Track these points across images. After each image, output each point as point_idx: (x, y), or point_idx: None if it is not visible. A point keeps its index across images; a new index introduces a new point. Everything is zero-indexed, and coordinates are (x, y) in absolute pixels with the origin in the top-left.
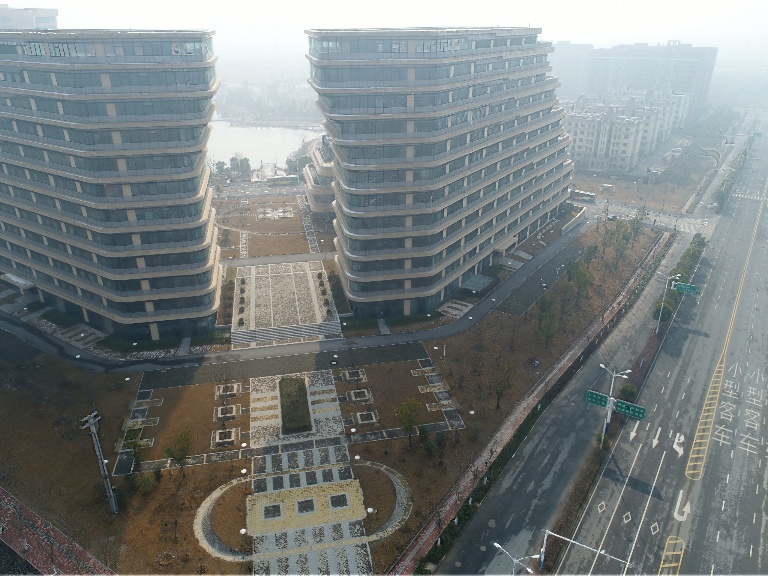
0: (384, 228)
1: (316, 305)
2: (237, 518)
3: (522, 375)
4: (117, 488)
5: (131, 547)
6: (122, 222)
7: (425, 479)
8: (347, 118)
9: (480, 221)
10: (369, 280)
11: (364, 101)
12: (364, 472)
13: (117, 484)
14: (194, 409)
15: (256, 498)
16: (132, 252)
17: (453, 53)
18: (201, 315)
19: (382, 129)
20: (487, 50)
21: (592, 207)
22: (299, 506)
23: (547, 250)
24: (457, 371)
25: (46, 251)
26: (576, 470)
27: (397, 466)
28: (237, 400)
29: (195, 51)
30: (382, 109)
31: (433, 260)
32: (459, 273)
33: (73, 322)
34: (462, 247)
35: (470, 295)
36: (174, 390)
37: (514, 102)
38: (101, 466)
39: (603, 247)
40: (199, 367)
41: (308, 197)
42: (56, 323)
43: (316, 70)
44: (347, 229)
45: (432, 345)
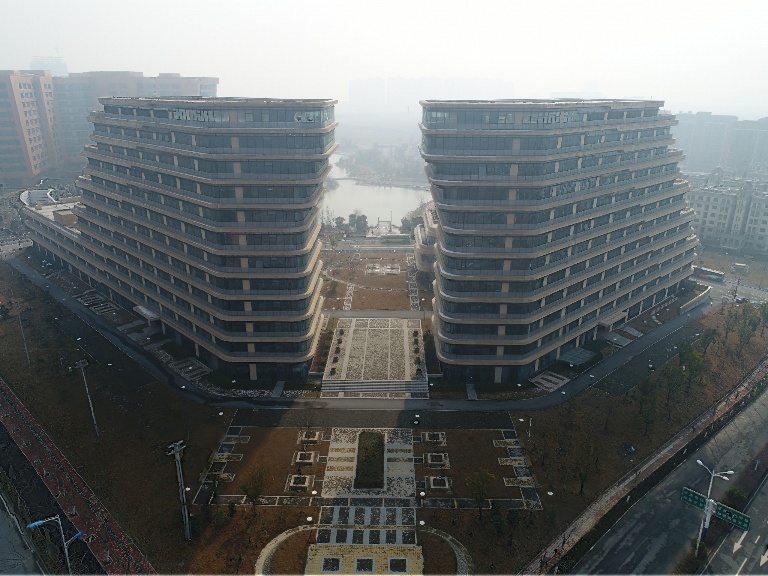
0: (479, 292)
1: (407, 362)
2: (297, 565)
3: (614, 461)
4: (194, 516)
5: (196, 575)
6: (236, 268)
7: (491, 557)
8: (449, 184)
9: (584, 293)
10: (460, 343)
11: (468, 168)
12: (428, 539)
13: (195, 513)
14: (276, 450)
15: (318, 548)
16: (241, 296)
17: (562, 125)
18: (296, 361)
19: (484, 196)
20: (600, 122)
21: (720, 287)
22: (358, 564)
23: (661, 329)
24: (542, 447)
25: (172, 289)
26: (663, 575)
27: (463, 539)
28: (317, 447)
29: (314, 119)
30: (485, 177)
31: (528, 329)
32: (557, 344)
33: (186, 355)
34: (562, 318)
35: (568, 368)
36: (261, 430)
37: (629, 174)
38: (181, 493)
39: (725, 331)
40: (287, 410)
41: (416, 256)
42: (172, 354)
43: (425, 138)
44: (443, 290)
45: (519, 416)
